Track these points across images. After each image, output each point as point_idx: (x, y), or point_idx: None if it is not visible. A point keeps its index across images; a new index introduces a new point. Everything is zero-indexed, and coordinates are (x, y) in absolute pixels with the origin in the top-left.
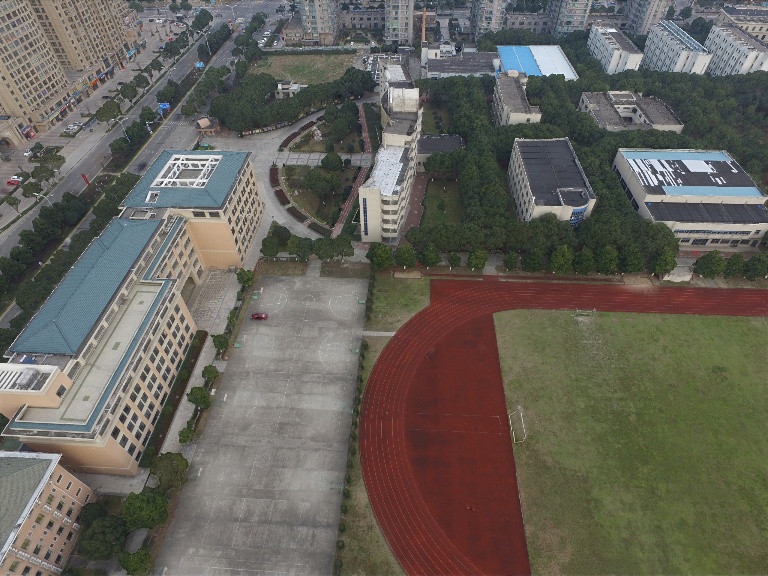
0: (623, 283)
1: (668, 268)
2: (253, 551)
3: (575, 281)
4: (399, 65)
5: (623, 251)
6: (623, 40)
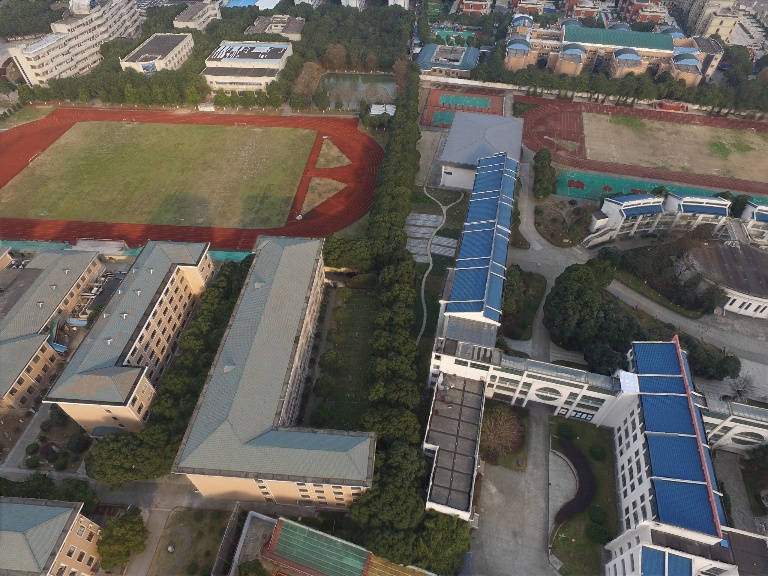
0: (173, 111)
1: (193, 99)
2: None
3: (145, 110)
4: None
5: None
6: None
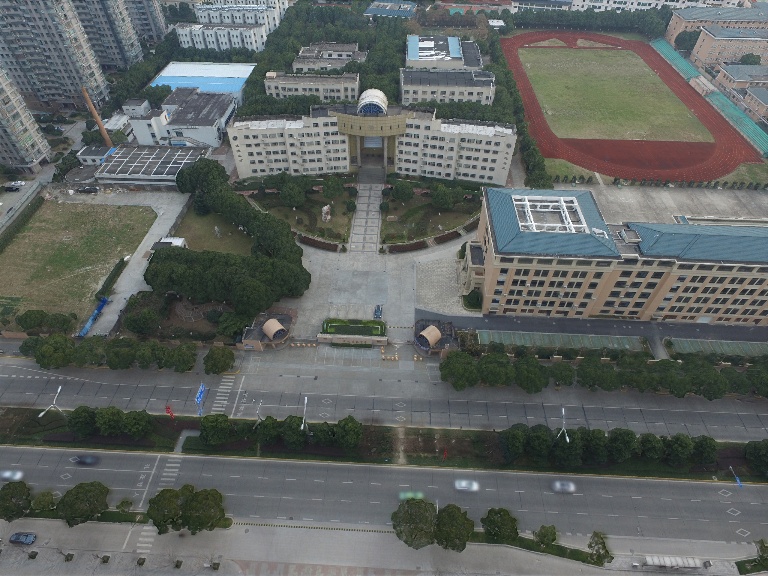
0: None
1: None
2: (767, 215)
3: None
4: (236, 122)
5: (510, 81)
6: (226, 26)
